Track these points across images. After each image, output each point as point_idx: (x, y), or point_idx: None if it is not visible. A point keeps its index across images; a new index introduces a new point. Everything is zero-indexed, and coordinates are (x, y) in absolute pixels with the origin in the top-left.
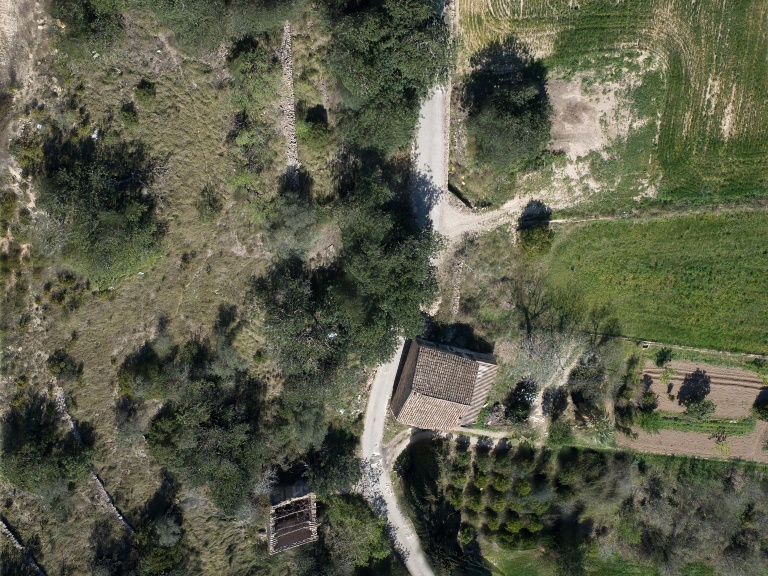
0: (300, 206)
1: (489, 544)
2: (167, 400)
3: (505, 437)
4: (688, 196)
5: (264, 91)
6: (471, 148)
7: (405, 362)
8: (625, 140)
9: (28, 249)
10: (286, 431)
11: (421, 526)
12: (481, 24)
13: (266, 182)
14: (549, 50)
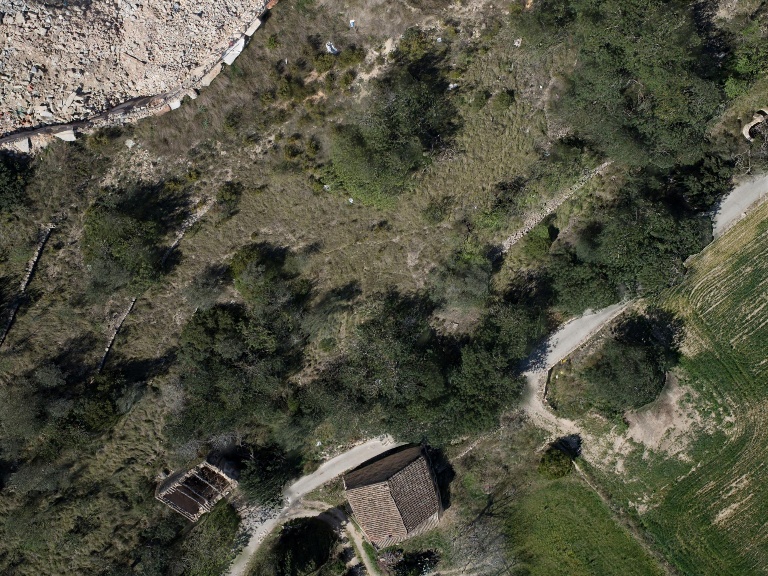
0: (488, 278)
1: None
2: (242, 302)
3: None
4: (658, 536)
5: (552, 184)
6: (591, 360)
7: (391, 455)
8: (666, 458)
9: (320, 98)
10: (277, 416)
11: None
12: (678, 293)
13: (479, 237)
14: (692, 354)
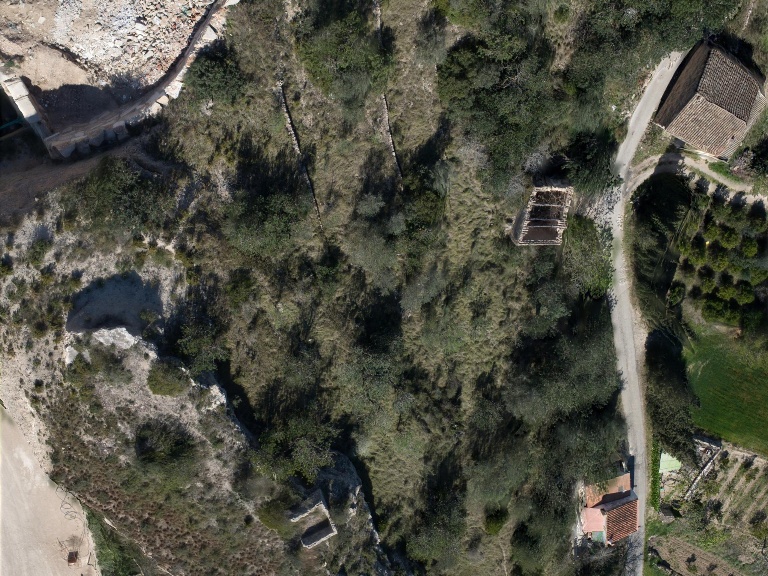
0: None
1: (692, 312)
2: (466, 33)
3: (743, 191)
4: None
5: None
6: None
7: (682, 72)
8: None
9: None
10: (564, 109)
11: (655, 259)
12: None
13: None
14: None
